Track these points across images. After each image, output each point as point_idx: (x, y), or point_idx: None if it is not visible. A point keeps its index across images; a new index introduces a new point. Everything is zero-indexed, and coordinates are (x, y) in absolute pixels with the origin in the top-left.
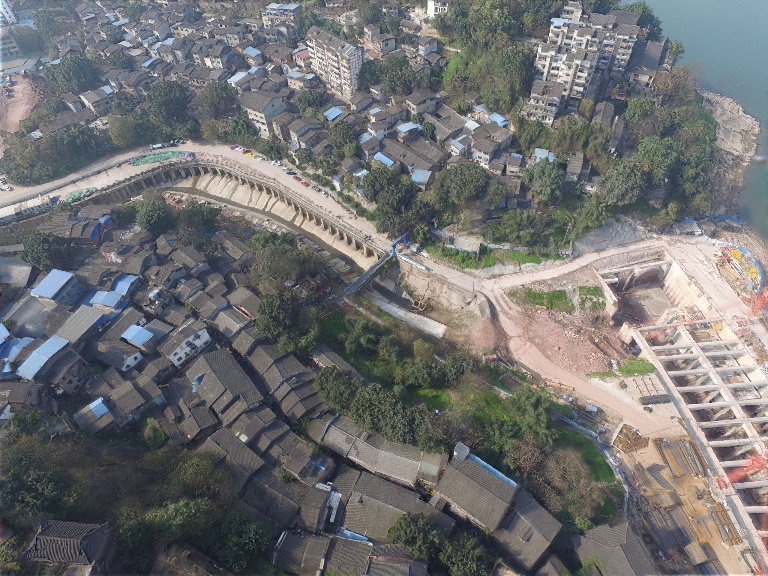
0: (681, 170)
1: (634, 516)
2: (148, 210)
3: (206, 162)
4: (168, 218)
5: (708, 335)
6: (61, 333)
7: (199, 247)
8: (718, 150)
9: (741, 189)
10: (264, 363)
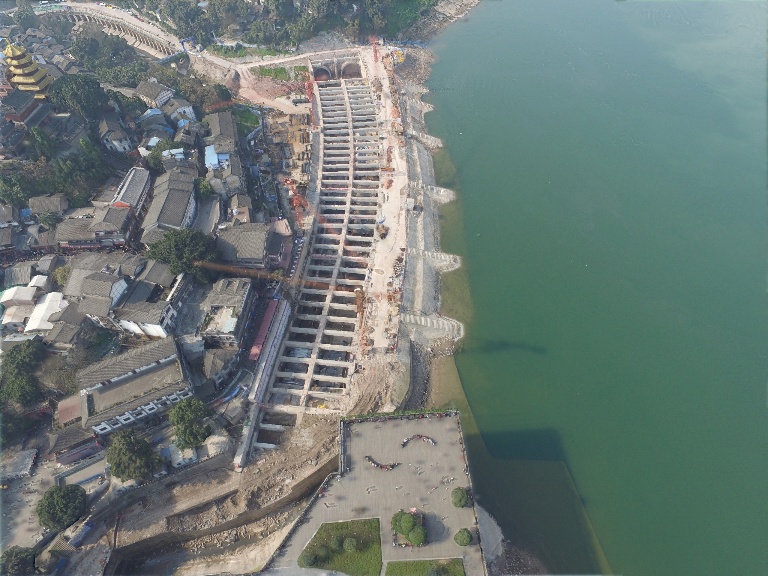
0: (365, 0)
1: None
2: (20, 11)
3: (79, 12)
4: (34, 19)
5: None
6: None
7: (54, 36)
8: (434, 11)
9: (439, 32)
10: (74, 72)
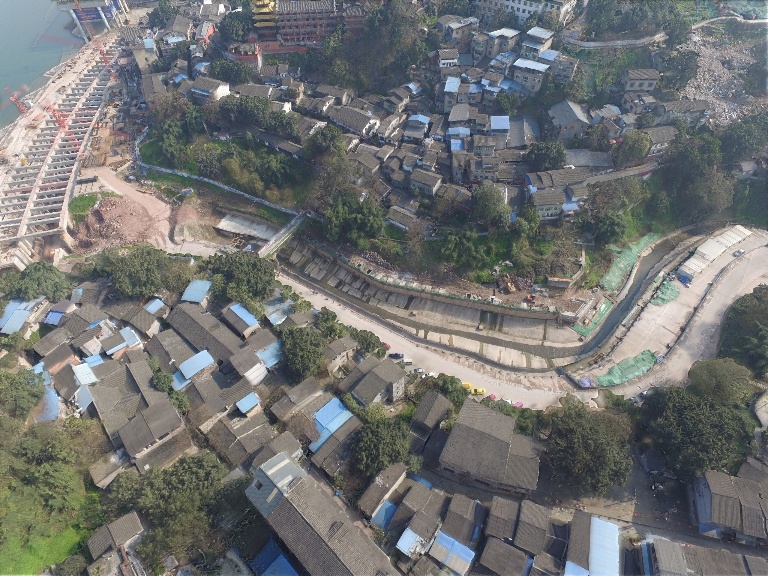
0: None
1: None
2: None
3: None
4: None
5: (0, 244)
6: (465, 107)
7: None
8: None
9: None
10: None
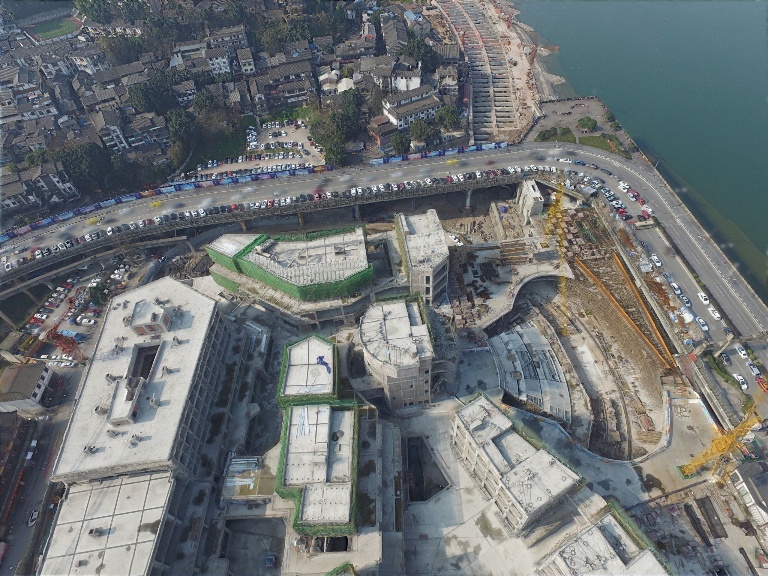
0: None
1: None
2: None
3: None
4: None
5: None
6: None
7: None
8: None
9: None
10: None
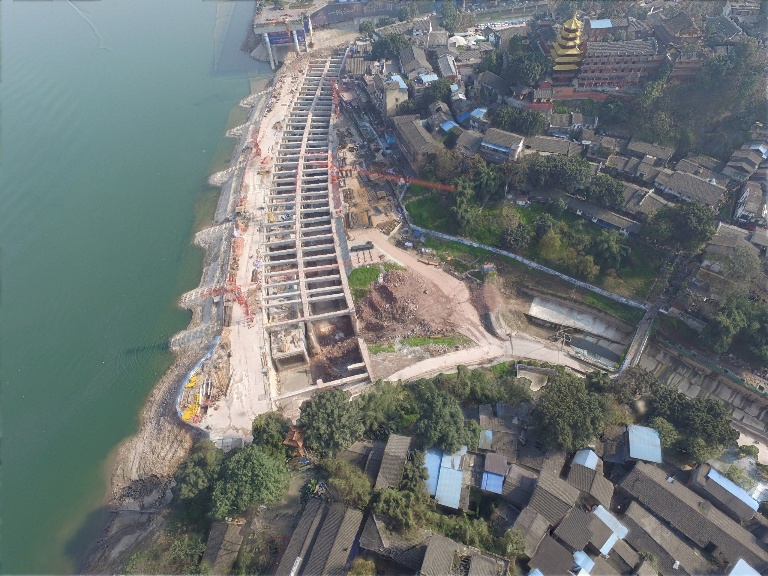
0: None
1: (399, 192)
2: None
3: None
4: None
5: None
6: None
7: None
8: None
9: None
10: None
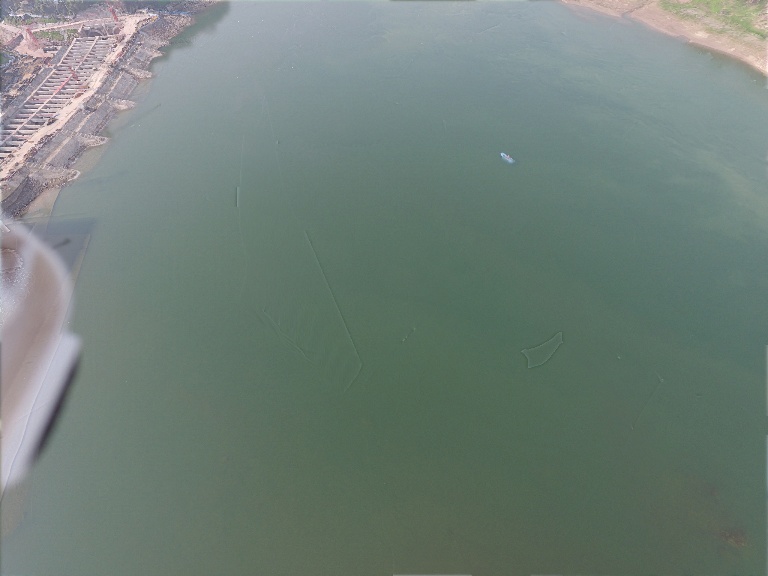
0: None
1: None
2: None
3: None
4: None
5: None
6: None
7: None
8: None
9: None
10: None
